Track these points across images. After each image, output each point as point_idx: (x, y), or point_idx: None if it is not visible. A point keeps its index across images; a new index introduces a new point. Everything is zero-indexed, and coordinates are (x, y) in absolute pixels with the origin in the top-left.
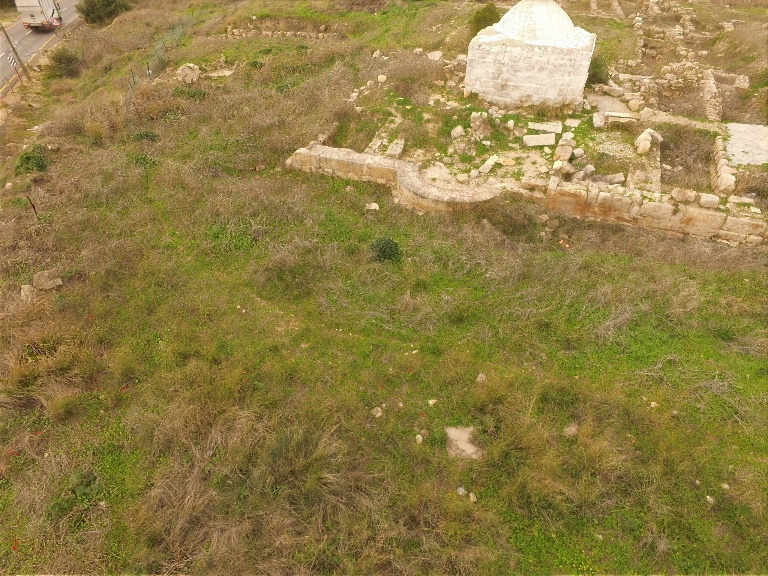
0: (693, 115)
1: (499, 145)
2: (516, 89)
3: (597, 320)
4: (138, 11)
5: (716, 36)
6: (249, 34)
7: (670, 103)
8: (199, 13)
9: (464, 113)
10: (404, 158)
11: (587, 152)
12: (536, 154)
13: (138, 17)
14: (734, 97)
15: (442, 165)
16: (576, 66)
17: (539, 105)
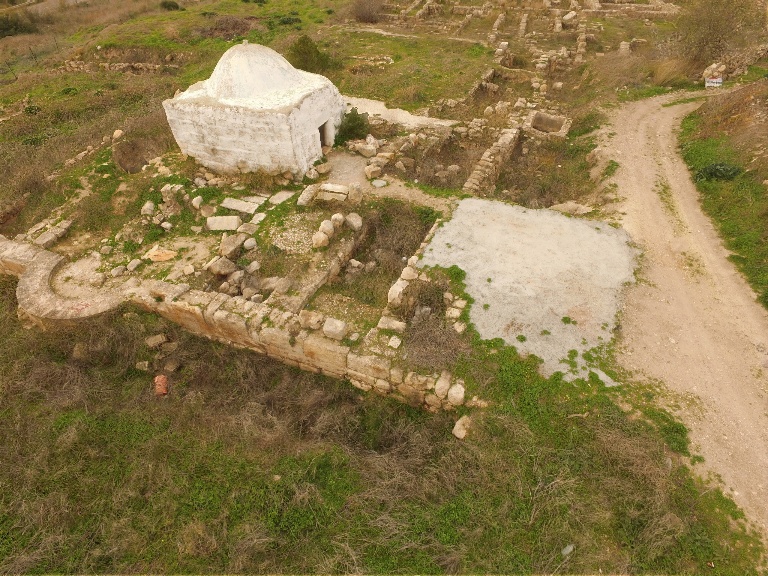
0: (438, 184)
1: (183, 227)
2: (227, 154)
3: (0, 557)
4: (13, 38)
5: (585, 63)
6: (85, 66)
7: (462, 157)
8: (82, 38)
9: (160, 185)
10: (57, 247)
11: (261, 243)
12: (206, 244)
13: (10, 44)
14: (542, 148)
15: (98, 256)
16: (276, 130)
17: (255, 173)
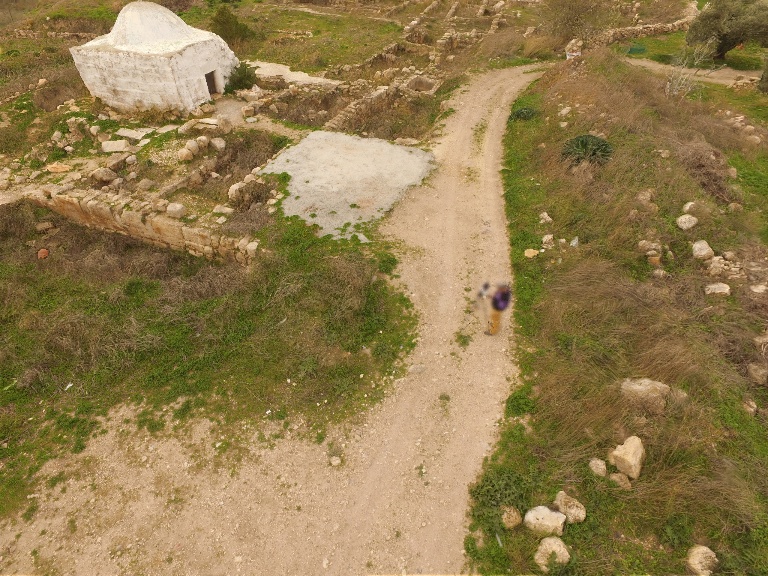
0: (301, 122)
1: (83, 151)
2: (126, 94)
3: None
4: None
5: None
6: None
7: None
8: (39, 13)
9: None
10: None
11: (140, 159)
12: (97, 161)
13: None
14: (411, 103)
15: (8, 171)
16: (161, 72)
17: (149, 111)
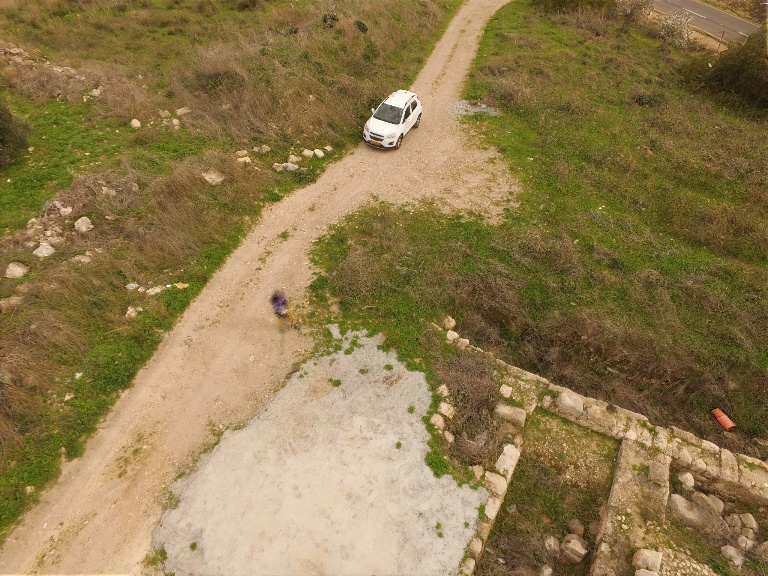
0: None
1: None
2: None
3: None
4: None
5: None
6: None
7: None
8: None
9: None
10: None
11: None
12: None
13: None
14: None
15: None
16: None
17: None
